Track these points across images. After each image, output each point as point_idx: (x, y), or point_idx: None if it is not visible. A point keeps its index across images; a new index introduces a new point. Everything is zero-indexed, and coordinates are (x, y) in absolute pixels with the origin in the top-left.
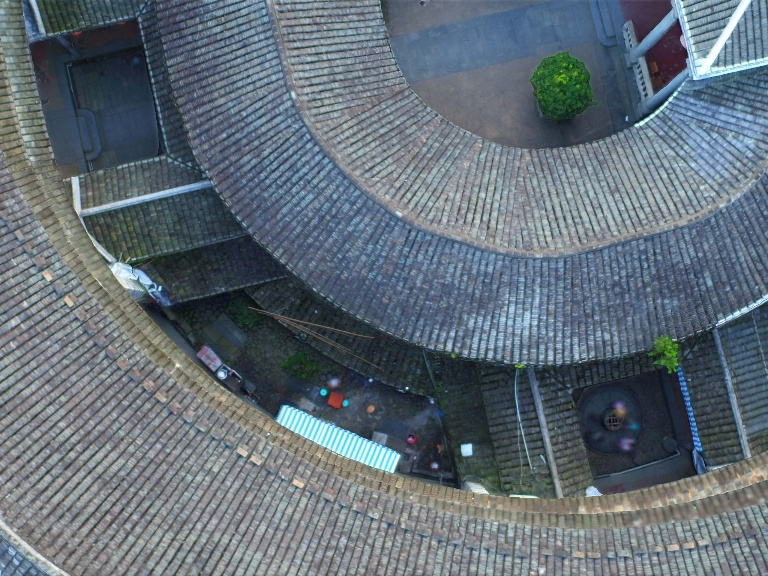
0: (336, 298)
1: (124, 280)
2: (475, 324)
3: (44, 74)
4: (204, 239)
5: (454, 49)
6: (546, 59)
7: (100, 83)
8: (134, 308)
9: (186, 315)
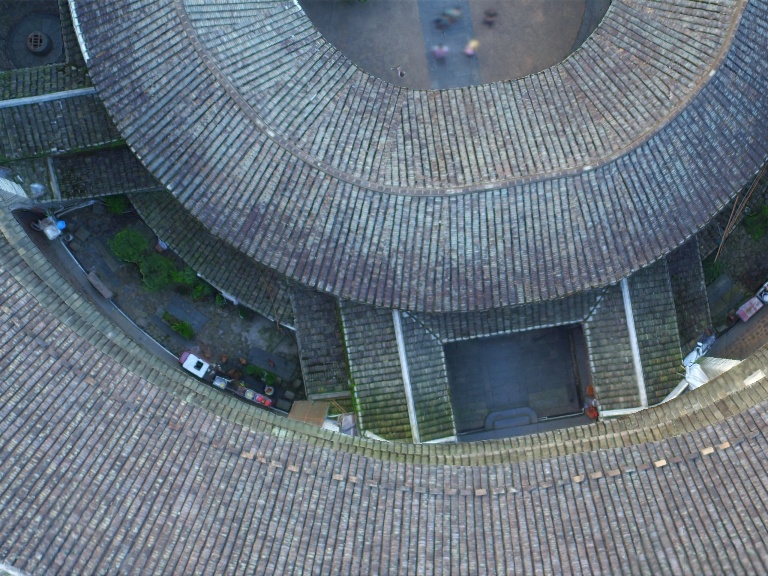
0: (767, 152)
1: None
2: None
3: None
4: (668, 292)
5: (451, 47)
6: None
7: (460, 405)
8: None
9: None
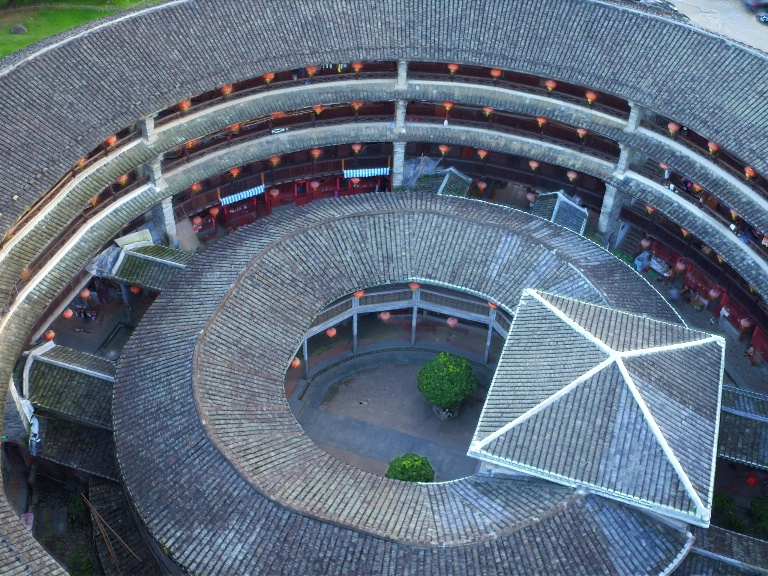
0: (126, 467)
1: (18, 398)
2: (199, 534)
3: (103, 320)
4: (90, 417)
5: (362, 438)
6: (408, 453)
7: None
8: (2, 395)
9: (43, 493)
